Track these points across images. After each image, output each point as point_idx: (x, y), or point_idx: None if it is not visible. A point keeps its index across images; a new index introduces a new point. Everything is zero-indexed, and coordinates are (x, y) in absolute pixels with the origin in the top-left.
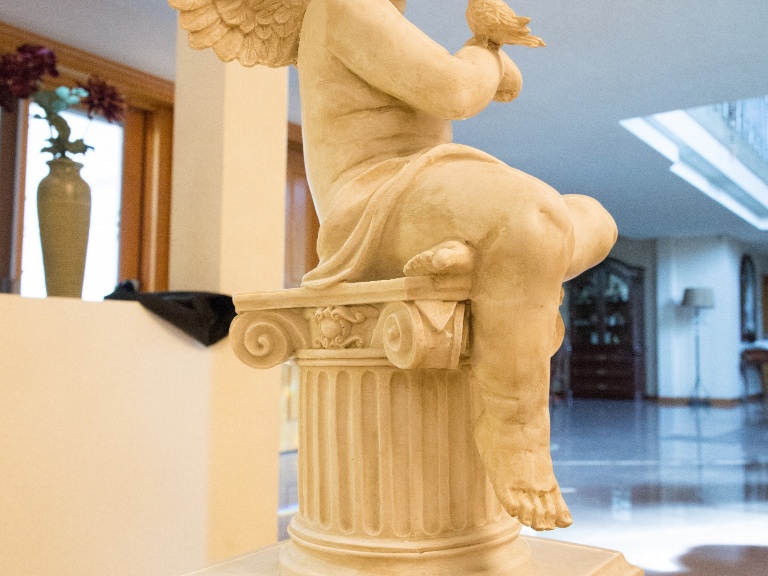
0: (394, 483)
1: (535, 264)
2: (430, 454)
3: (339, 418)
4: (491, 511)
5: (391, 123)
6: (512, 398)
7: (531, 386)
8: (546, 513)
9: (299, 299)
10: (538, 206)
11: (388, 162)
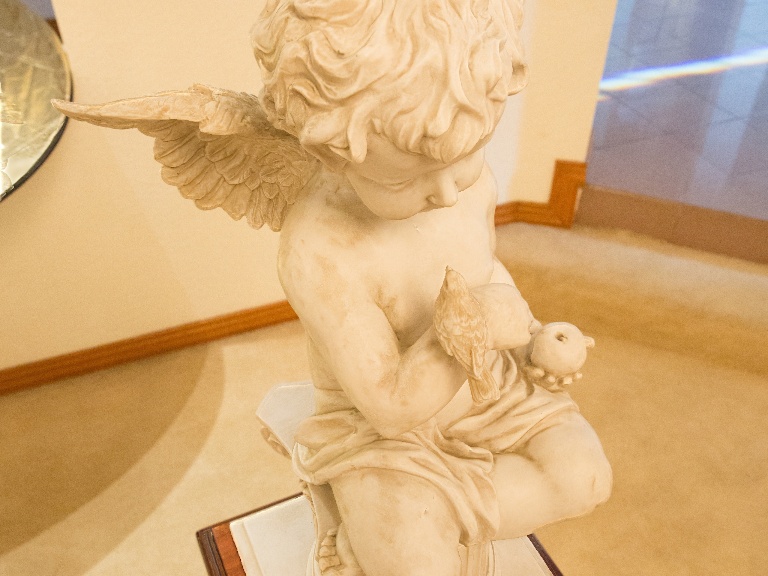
0: None
1: None
2: None
3: None
4: None
5: None
6: None
7: None
8: None
9: None
10: None
11: (342, 419)
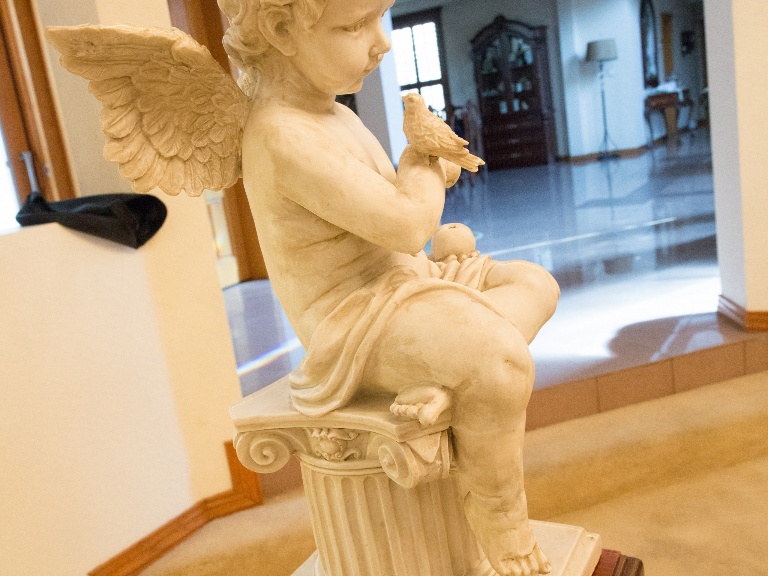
0: (404, 558)
1: (506, 406)
2: (430, 529)
3: (349, 514)
4: (482, 552)
5: (350, 249)
6: (496, 497)
7: (510, 485)
8: (531, 570)
9: (295, 422)
10: (503, 358)
11: (355, 296)
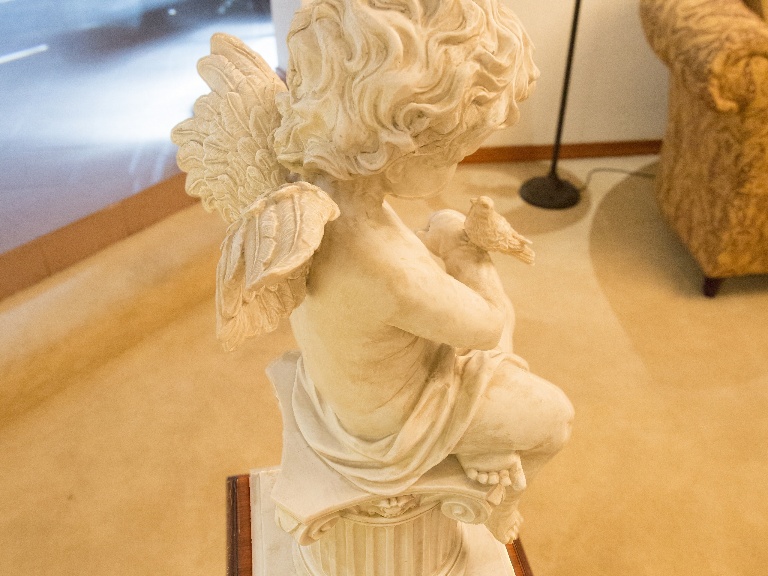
0: None
1: None
2: None
3: (395, 546)
4: None
5: None
6: (516, 499)
7: None
8: None
9: None
10: None
11: (434, 391)
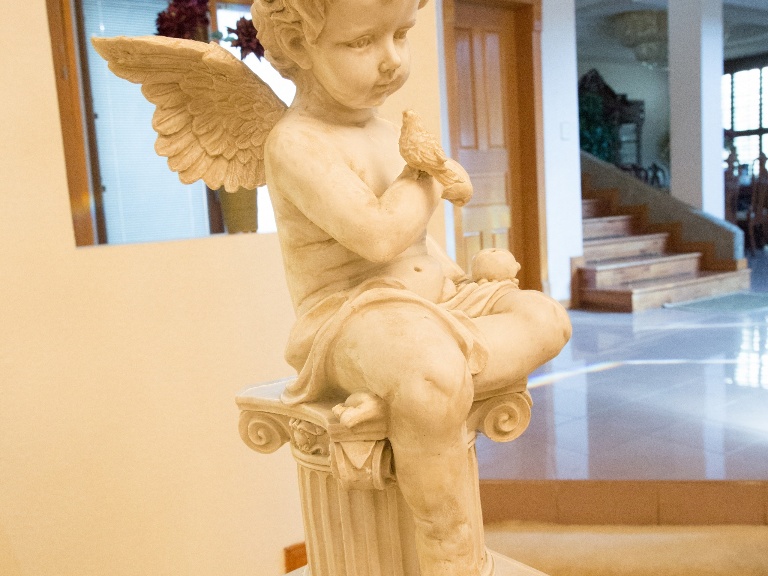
0: (357, 564)
1: (424, 425)
2: (385, 542)
3: (315, 507)
4: None
5: (340, 254)
6: (427, 521)
7: (442, 513)
8: None
9: (278, 408)
10: (423, 375)
11: (332, 298)
